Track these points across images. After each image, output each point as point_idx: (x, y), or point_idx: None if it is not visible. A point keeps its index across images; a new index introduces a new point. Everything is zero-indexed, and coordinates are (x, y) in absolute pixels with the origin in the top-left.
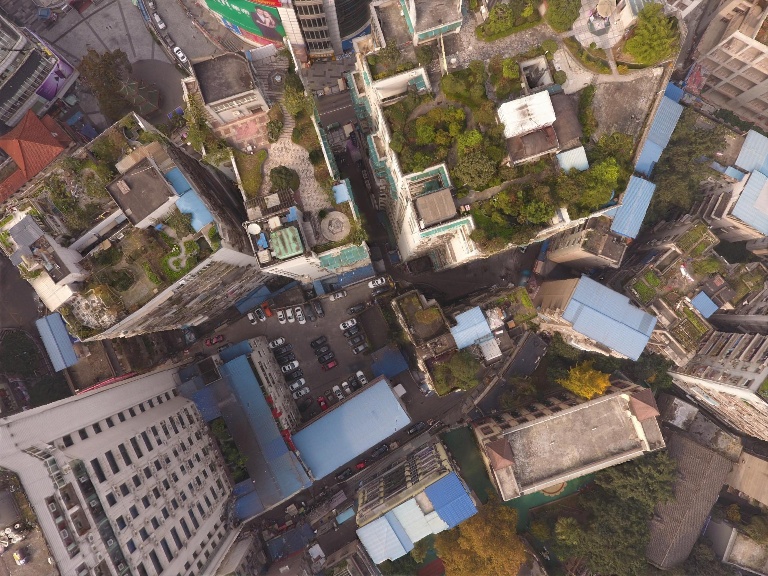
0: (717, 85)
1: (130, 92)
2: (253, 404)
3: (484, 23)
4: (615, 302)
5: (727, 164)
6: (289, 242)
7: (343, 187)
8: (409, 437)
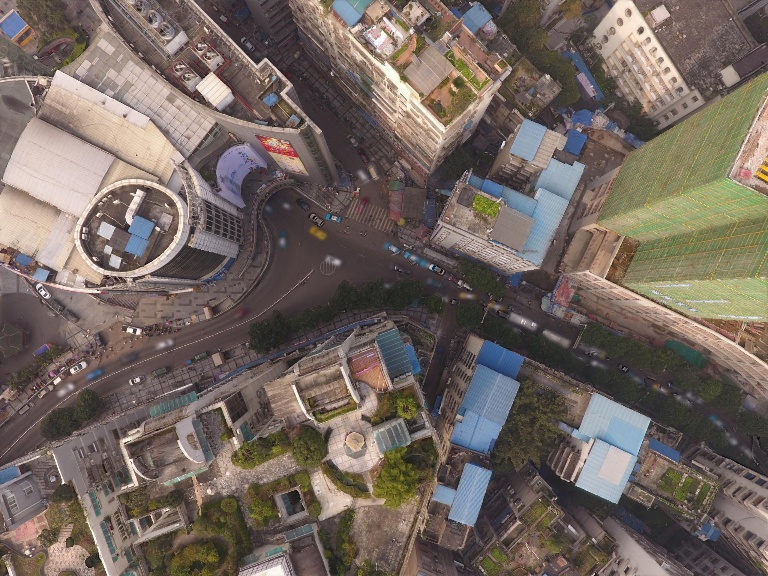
0: (589, 290)
1: None
2: None
3: None
4: None
5: (575, 422)
6: None
7: None
8: None
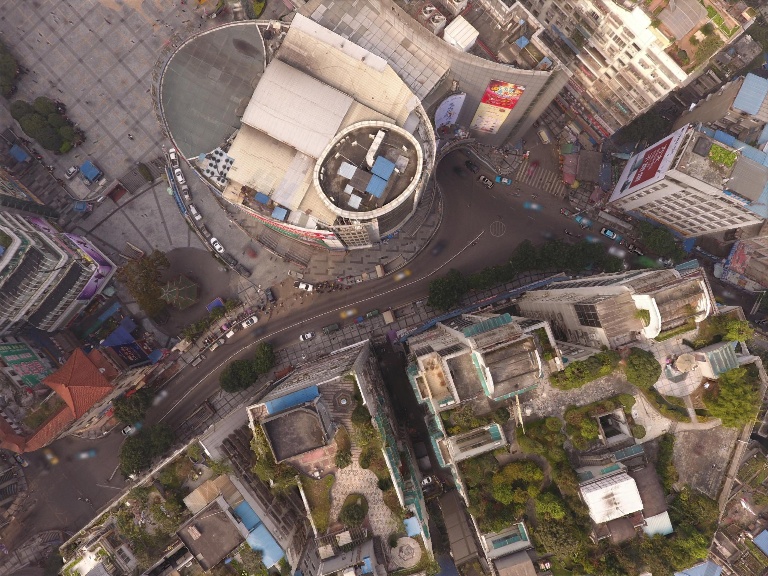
0: (760, 258)
1: (171, 298)
2: None
3: (559, 375)
4: None
5: None
6: None
7: (414, 520)
8: None
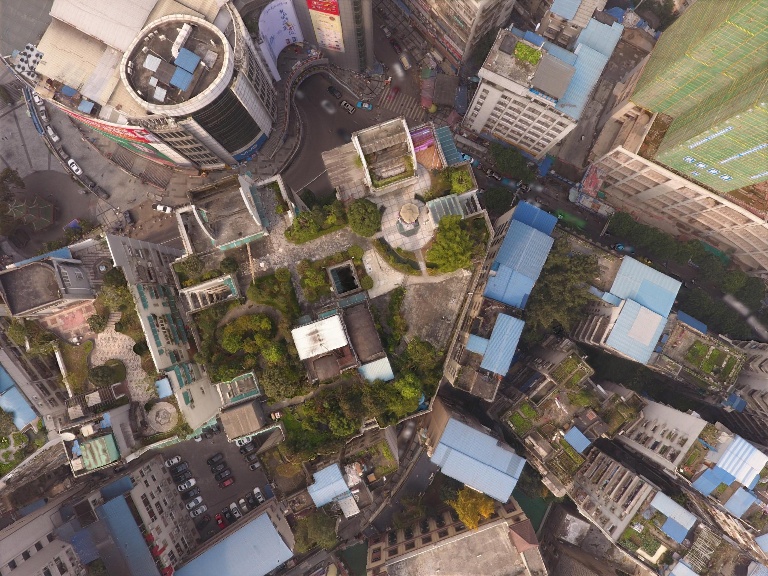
0: (616, 184)
1: (18, 214)
2: (131, 545)
3: (291, 228)
4: (483, 444)
5: (606, 287)
6: (99, 454)
7: (165, 382)
8: (307, 553)
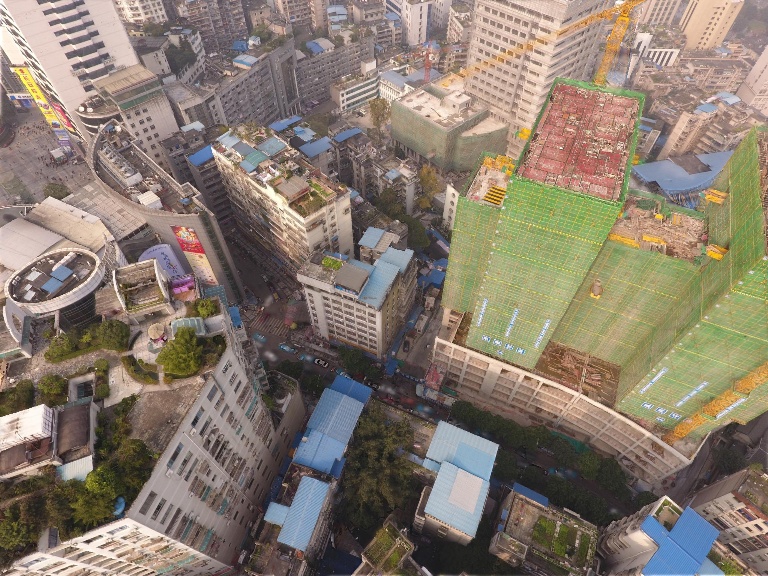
0: (460, 380)
1: None
2: None
3: None
4: None
5: None
6: None
7: None
8: None
